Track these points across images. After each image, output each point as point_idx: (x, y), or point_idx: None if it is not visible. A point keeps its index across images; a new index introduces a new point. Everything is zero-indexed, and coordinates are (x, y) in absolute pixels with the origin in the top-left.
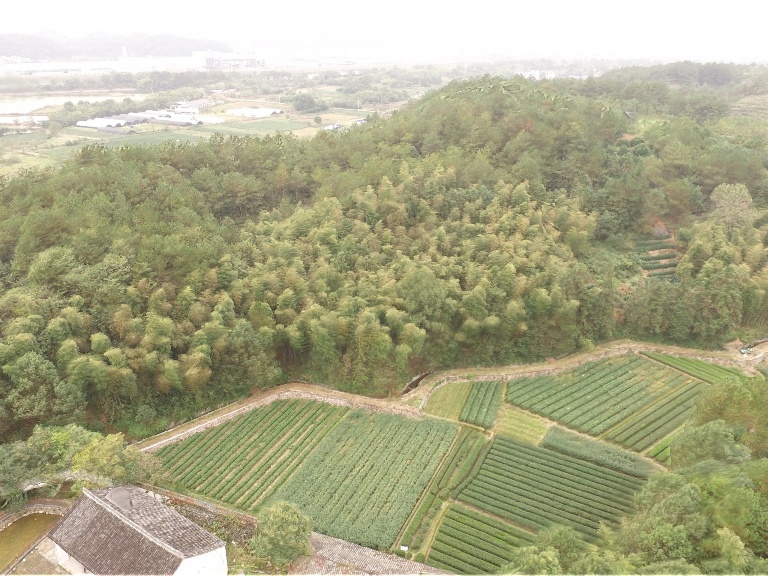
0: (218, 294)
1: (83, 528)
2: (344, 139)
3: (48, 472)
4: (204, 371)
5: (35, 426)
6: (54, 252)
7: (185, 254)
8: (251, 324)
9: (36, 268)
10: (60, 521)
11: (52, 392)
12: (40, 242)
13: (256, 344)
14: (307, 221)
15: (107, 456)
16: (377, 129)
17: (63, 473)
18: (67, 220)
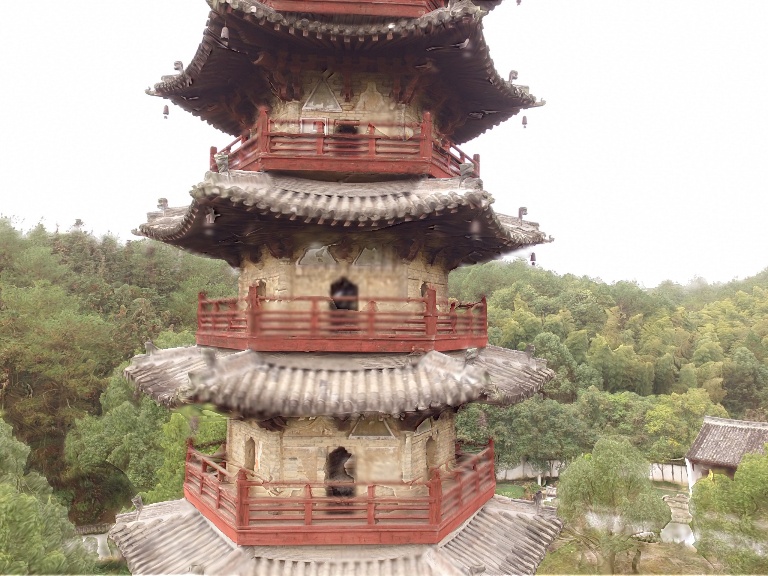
0: (691, 333)
1: (740, 447)
2: (698, 282)
3: (611, 434)
4: (718, 390)
5: (578, 390)
6: (518, 283)
7: (643, 296)
8: (753, 353)
9: (500, 298)
10: (694, 445)
11: (570, 376)
12: (488, 288)
13: (766, 374)
14: (730, 307)
15: (703, 403)
16: (718, 286)
17: (630, 437)
18: (505, 277)
